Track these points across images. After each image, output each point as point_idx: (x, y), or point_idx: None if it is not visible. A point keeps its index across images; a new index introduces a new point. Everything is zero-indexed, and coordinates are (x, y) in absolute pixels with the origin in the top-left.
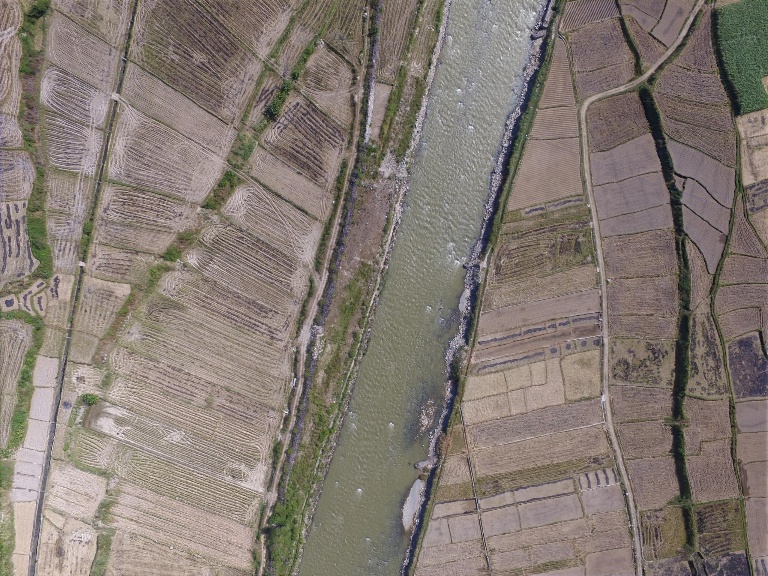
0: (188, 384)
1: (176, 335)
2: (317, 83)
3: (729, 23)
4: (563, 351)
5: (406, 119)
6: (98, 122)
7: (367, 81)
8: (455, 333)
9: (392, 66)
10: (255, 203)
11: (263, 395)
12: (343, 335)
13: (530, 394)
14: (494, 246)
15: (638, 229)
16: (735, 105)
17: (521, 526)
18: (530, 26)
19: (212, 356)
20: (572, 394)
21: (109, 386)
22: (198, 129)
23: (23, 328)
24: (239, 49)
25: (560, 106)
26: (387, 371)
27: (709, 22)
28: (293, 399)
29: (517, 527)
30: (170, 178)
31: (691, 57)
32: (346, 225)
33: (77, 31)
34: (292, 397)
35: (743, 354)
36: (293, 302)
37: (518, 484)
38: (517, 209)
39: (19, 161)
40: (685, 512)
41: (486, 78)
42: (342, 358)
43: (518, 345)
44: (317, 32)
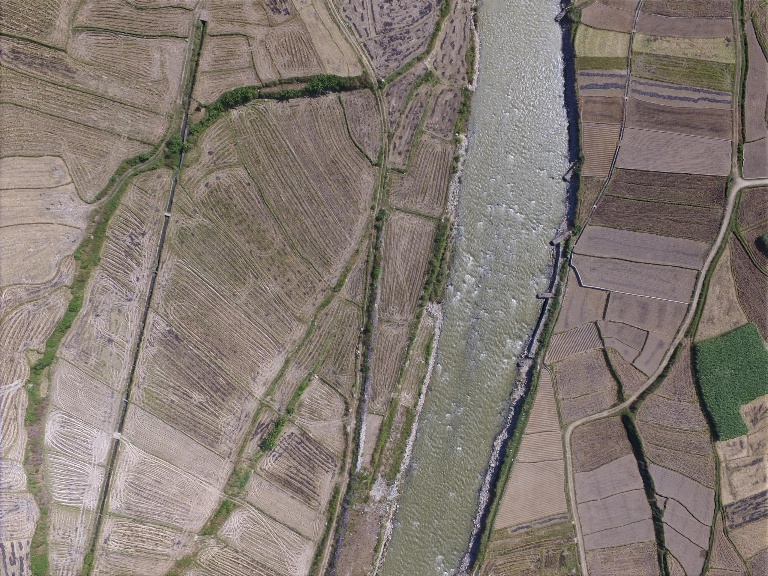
0: None
1: None
2: (311, 414)
3: (708, 360)
4: None
5: (397, 446)
6: (100, 460)
7: (359, 414)
8: None
9: (383, 398)
10: (250, 525)
11: None
12: None
13: None
14: (481, 563)
15: (621, 542)
16: (714, 433)
17: None
18: (516, 354)
19: None
20: None
21: None
22: (196, 463)
23: None
24: (236, 389)
25: (545, 431)
26: None
27: (689, 355)
28: None
29: None
30: (169, 509)
31: (671, 387)
32: (338, 548)
33: (81, 376)
34: None
35: None
36: None
37: None
38: (504, 528)
39: (24, 502)
40: None
41: (474, 403)
42: None
43: None
44: (311, 369)
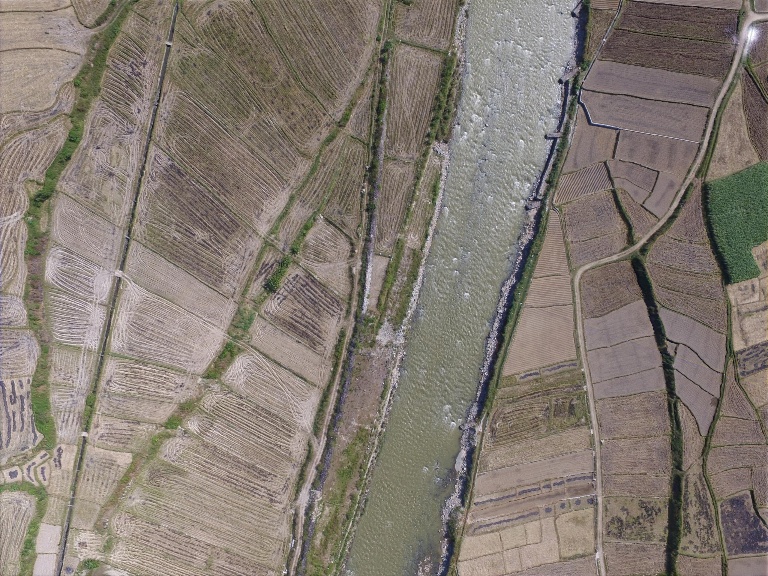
0: (188, 547)
1: (177, 499)
2: (316, 255)
3: (719, 198)
4: (558, 510)
5: (403, 289)
6: (101, 298)
7: (365, 255)
8: (451, 492)
9: (389, 239)
10: (255, 371)
11: (262, 556)
12: (341, 498)
13: (525, 552)
14: (489, 411)
15: (631, 391)
16: (725, 275)
17: None
18: (524, 197)
19: (212, 519)
20: (567, 551)
21: (110, 550)
22: (199, 303)
23: (26, 499)
24: (240, 226)
25: (554, 275)
26: (384, 530)
27: (700, 195)
28: (291, 560)
29: None
30: (172, 351)
31: (682, 229)
32: (344, 393)
33: (82, 212)
34: (291, 558)
35: (735, 512)
36: (292, 465)
37: None
38: (512, 374)
39: (24, 339)
40: None
41: (481, 247)
42: (340, 520)
43: (513, 505)
44: (316, 208)
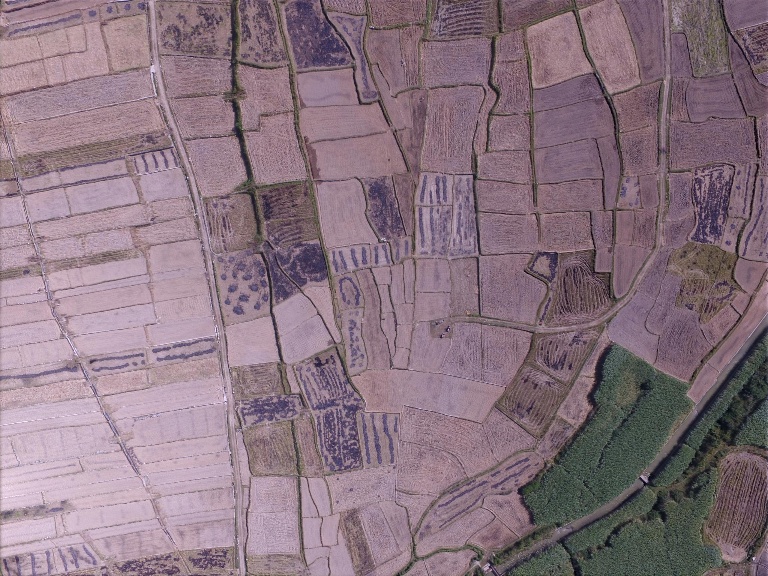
0: None
1: None
2: None
3: None
4: (104, 15)
5: None
6: None
7: None
8: None
9: None
10: None
11: None
12: None
13: (69, 62)
14: None
15: None
16: None
17: (71, 211)
18: None
19: None
20: (119, 65)
21: None
22: None
23: None
24: None
25: None
26: None
27: None
28: None
29: (66, 212)
30: None
31: None
32: None
33: None
34: None
35: (303, 18)
36: None
37: (64, 164)
38: None
39: None
40: (252, 198)
41: None
42: None
43: (53, 7)
44: None
